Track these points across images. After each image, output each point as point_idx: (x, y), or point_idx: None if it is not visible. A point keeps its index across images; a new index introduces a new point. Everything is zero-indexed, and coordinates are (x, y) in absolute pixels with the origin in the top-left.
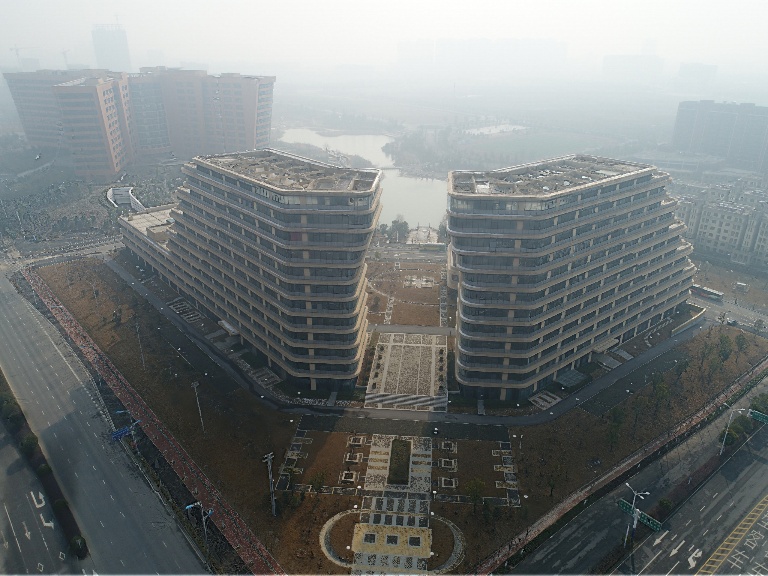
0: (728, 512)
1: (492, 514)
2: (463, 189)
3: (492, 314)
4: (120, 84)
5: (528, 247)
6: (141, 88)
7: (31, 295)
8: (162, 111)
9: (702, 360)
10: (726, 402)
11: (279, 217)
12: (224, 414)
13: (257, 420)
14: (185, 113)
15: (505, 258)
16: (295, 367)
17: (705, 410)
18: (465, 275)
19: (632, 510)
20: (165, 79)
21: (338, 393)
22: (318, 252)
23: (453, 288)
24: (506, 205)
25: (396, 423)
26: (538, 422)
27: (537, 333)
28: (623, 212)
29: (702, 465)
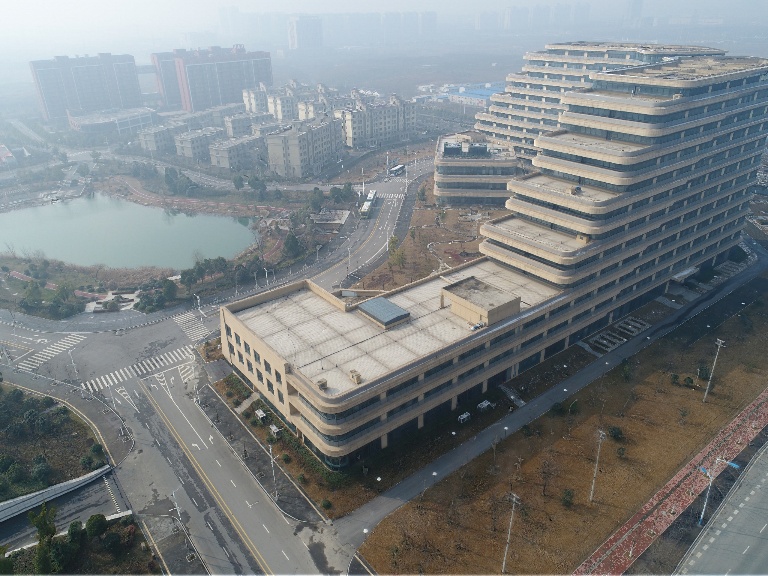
0: None
1: None
2: None
3: None
4: None
5: None
6: None
7: (650, 569)
8: None
9: None
10: None
11: None
12: None
13: None
14: None
15: None
16: None
17: None
18: None
19: None
20: None
21: None
22: None
23: None
24: None
25: None
26: None
27: None
28: None
29: None
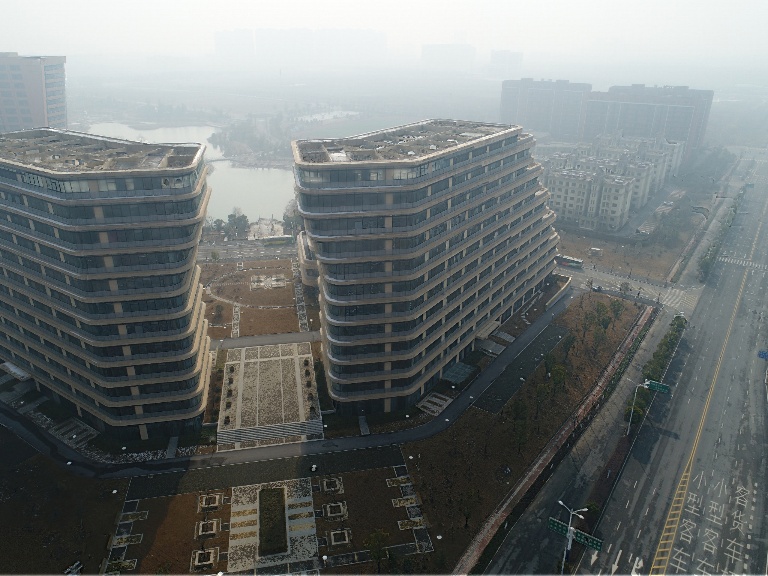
0: (653, 502)
1: (402, 571)
2: (313, 160)
3: (366, 311)
4: None
5: (401, 225)
6: None
7: None
8: None
9: (584, 332)
10: (616, 374)
11: (61, 212)
12: (11, 499)
13: (63, 498)
14: None
15: (375, 241)
16: (114, 414)
17: (599, 386)
18: (328, 267)
19: (565, 529)
20: None
21: (179, 438)
22: (126, 256)
23: (309, 285)
24: (370, 174)
25: (261, 466)
26: (433, 433)
27: (419, 327)
28: (495, 178)
29: (613, 451)
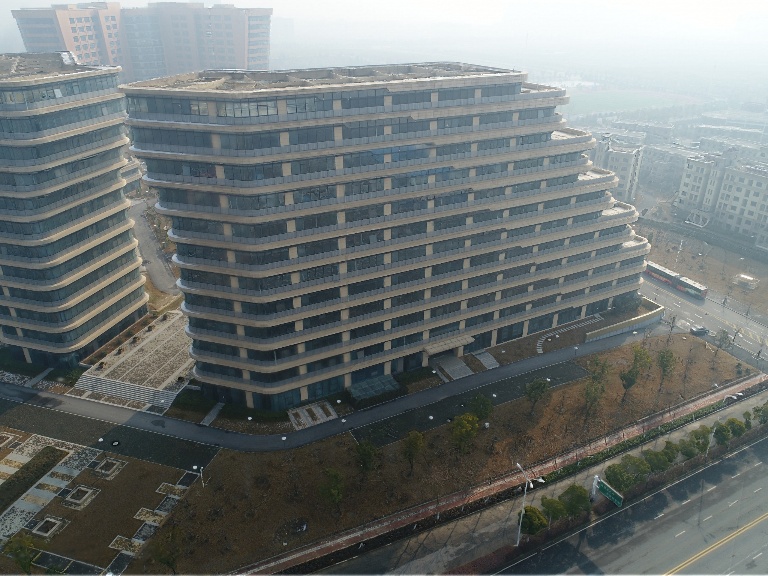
0: None
1: None
2: None
3: (210, 280)
4: (102, 13)
5: (235, 178)
6: (135, 21)
7: None
8: (159, 47)
9: None
10: (596, 454)
11: None
12: None
13: None
14: (180, 50)
15: (208, 194)
16: (3, 330)
17: (553, 463)
18: None
19: None
20: (162, 12)
21: None
22: None
23: None
24: (191, 107)
25: (79, 422)
26: (270, 448)
27: (286, 315)
28: (452, 140)
29: (471, 561)
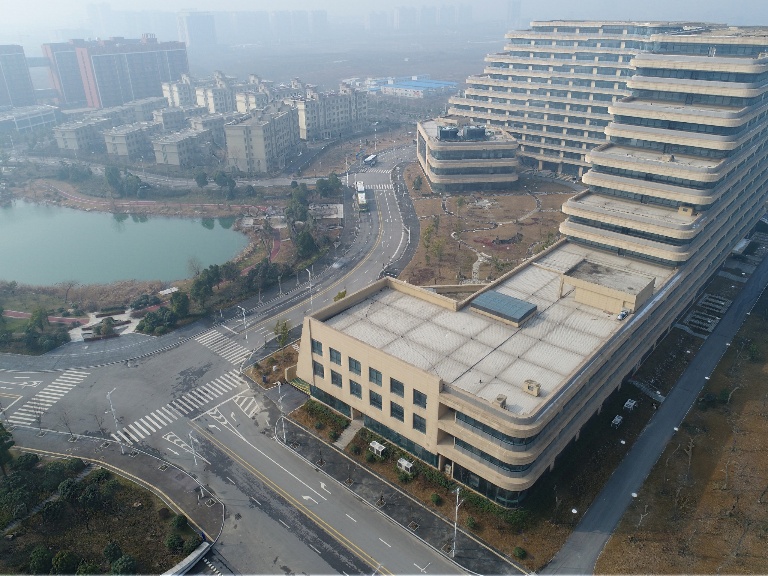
0: None
1: None
2: None
3: None
4: None
5: None
6: None
7: None
8: None
9: None
10: None
11: None
12: None
13: None
14: None
15: None
16: None
17: None
18: None
19: None
20: None
21: None
22: None
23: None
24: None
25: None
26: None
27: None
28: None
29: None
